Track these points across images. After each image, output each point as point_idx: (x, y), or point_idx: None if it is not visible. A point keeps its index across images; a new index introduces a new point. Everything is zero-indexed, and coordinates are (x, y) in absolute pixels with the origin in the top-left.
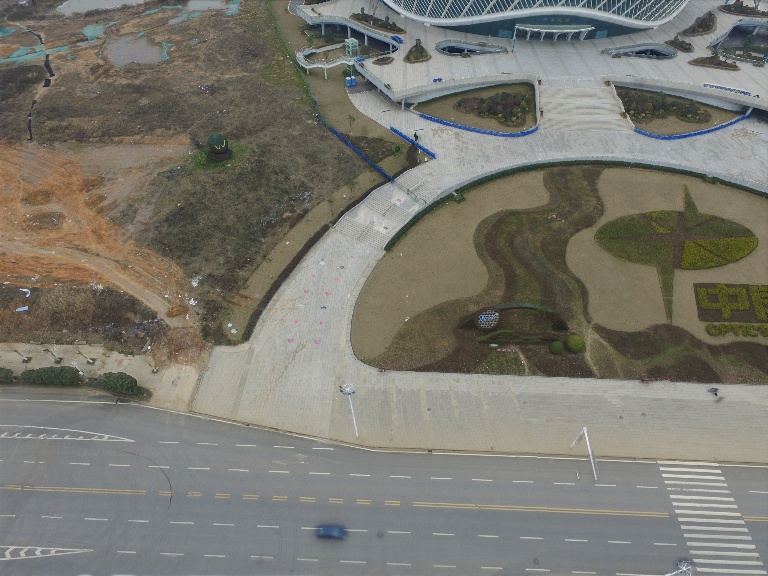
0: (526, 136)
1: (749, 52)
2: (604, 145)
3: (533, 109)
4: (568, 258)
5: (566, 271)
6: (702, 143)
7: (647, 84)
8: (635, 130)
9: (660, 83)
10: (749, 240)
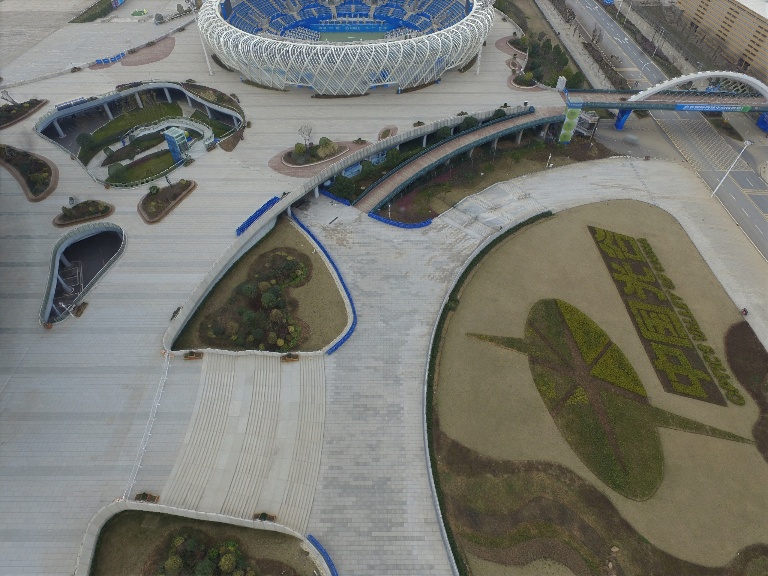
0: (341, 574)
1: (101, 151)
2: (376, 415)
3: (227, 532)
4: (704, 561)
5: (736, 573)
6: (365, 282)
7: (201, 295)
8: (329, 353)
9: (210, 278)
10: (567, 308)
